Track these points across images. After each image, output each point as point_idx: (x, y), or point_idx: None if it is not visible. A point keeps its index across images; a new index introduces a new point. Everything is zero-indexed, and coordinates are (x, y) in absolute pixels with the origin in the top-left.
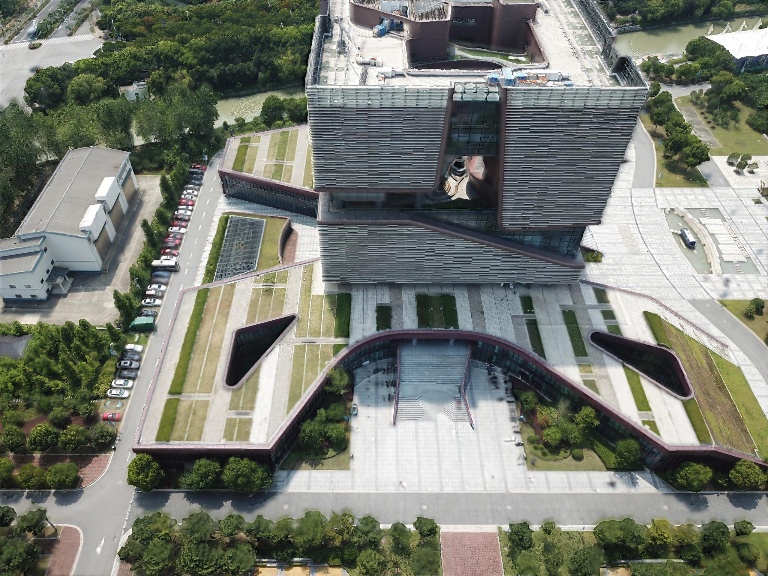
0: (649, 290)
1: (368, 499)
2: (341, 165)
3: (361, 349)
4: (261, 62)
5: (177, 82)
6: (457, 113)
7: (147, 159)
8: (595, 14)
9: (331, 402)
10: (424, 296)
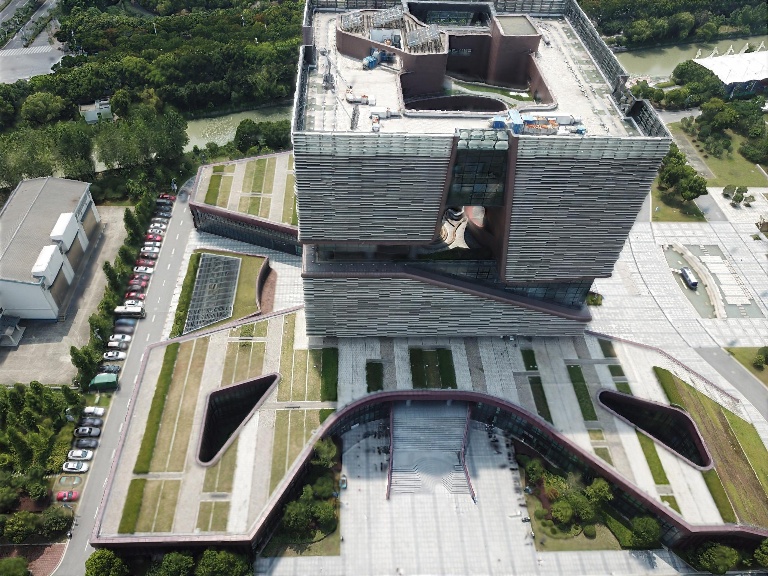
0: (653, 337)
1: None
2: (330, 216)
3: (350, 413)
4: (234, 81)
5: (143, 101)
6: (461, 162)
7: (110, 188)
8: (604, 49)
9: (317, 474)
10: (418, 351)
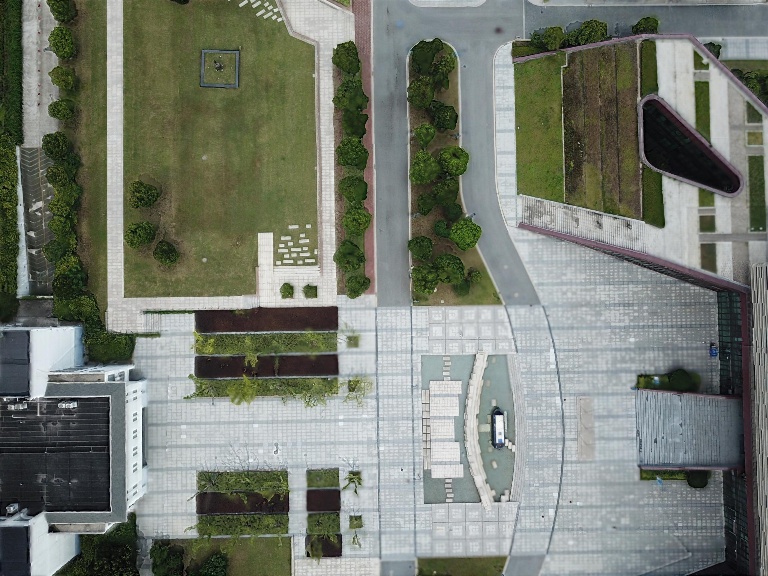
0: (587, 321)
1: None
2: None
3: None
4: None
5: None
6: None
7: None
8: None
9: None
10: None
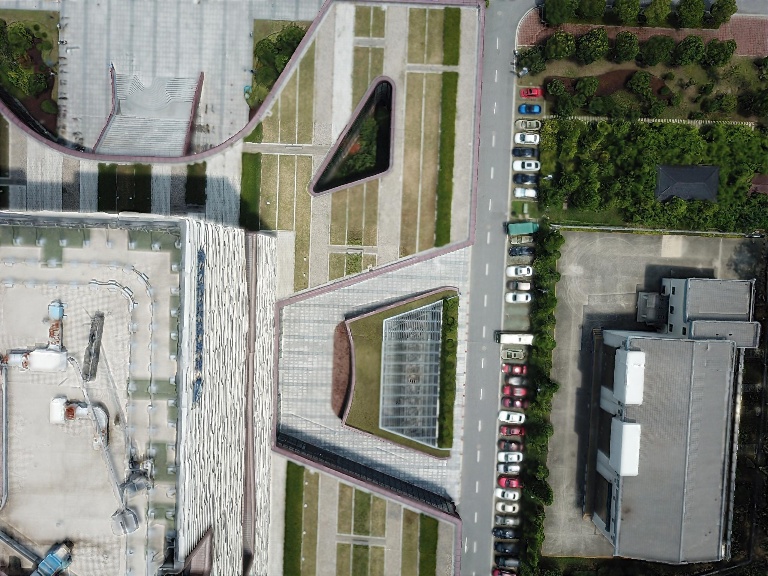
0: None
1: None
2: None
3: None
4: None
5: None
6: None
7: None
8: None
9: None
10: None
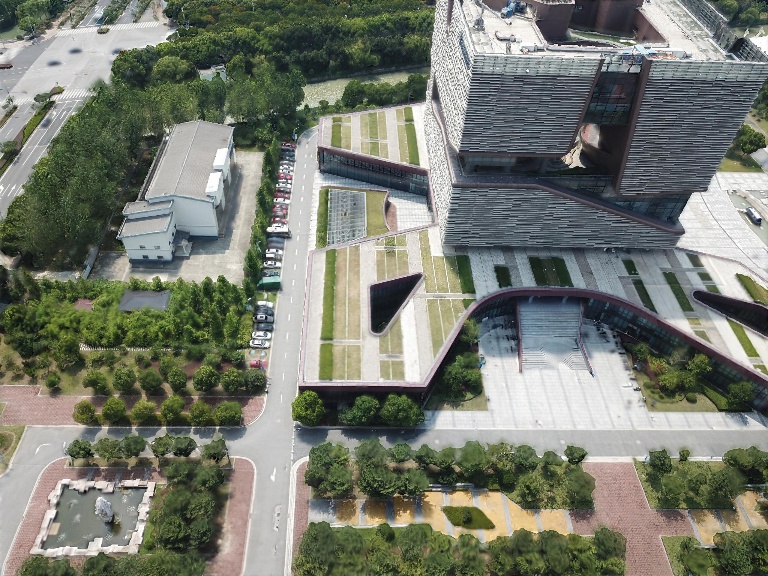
0: None
1: (510, 435)
2: (488, 130)
3: (485, 304)
4: (332, 51)
5: (255, 67)
6: (600, 83)
7: (240, 136)
8: (701, 3)
9: (460, 352)
10: (537, 258)
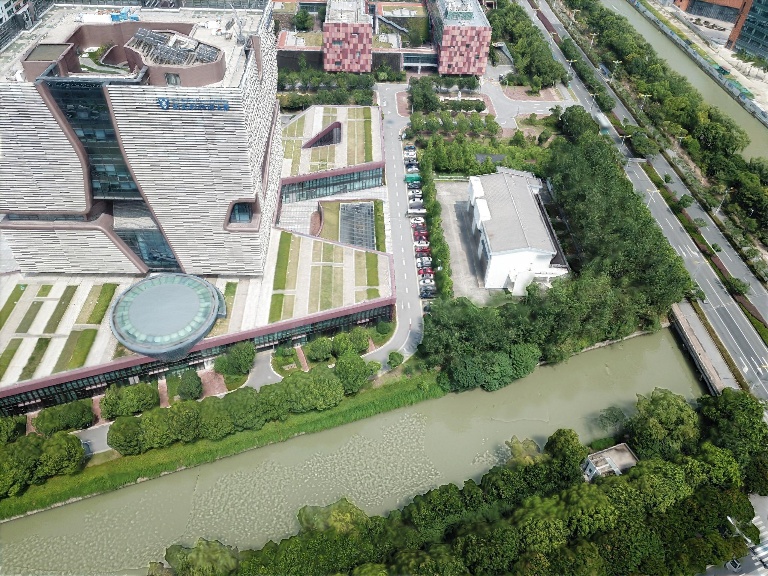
0: None
1: None
2: None
3: None
4: None
5: None
6: None
7: None
8: None
9: None
10: None
